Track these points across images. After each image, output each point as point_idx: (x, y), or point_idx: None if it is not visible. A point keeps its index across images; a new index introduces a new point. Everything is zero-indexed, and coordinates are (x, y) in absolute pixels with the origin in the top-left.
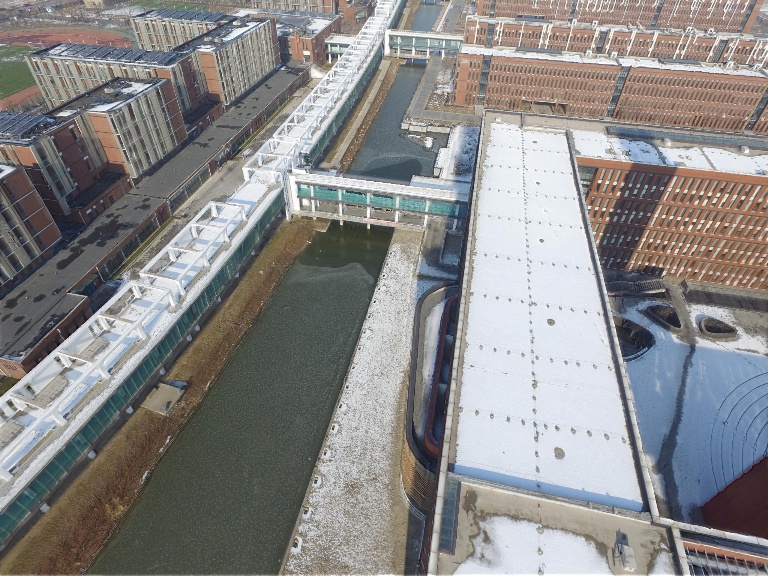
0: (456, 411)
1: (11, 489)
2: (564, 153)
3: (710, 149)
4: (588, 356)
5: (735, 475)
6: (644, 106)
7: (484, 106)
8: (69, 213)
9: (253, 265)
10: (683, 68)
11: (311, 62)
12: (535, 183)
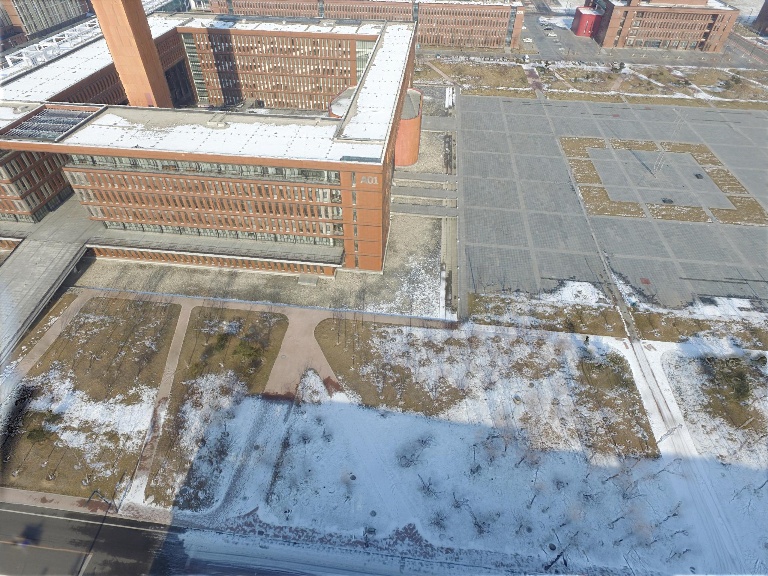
0: None
1: None
2: None
3: (266, 23)
4: (77, 78)
5: None
6: None
7: None
8: None
9: None
10: None
11: None
12: None
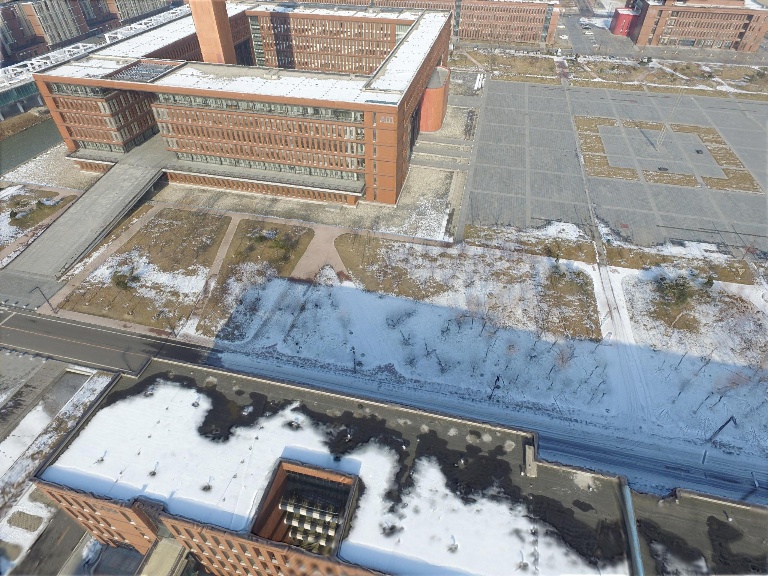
0: (103, 49)
1: None
2: None
3: (320, 9)
4: None
5: None
6: None
7: None
8: (11, 54)
9: None
10: None
11: None
12: None
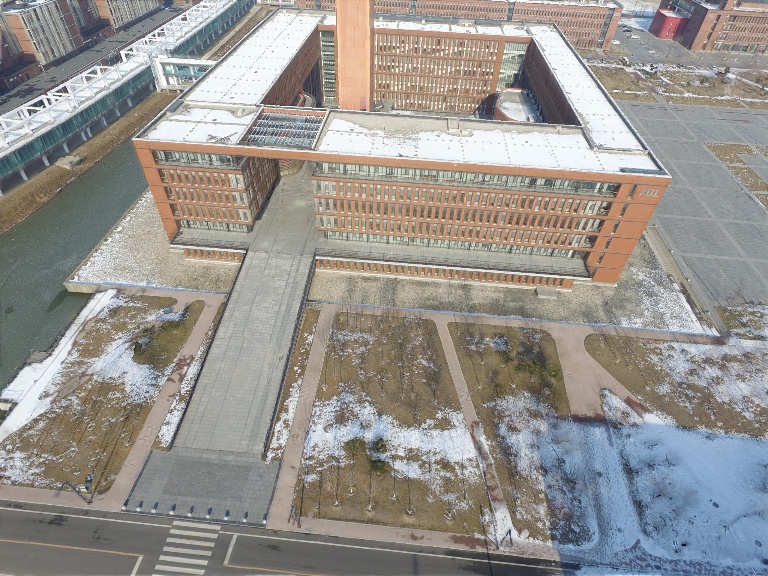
0: (193, 90)
1: None
2: (314, 24)
3: (404, 22)
4: (266, 79)
5: None
6: None
7: None
8: None
9: (131, 111)
10: None
11: (191, 4)
12: (286, 34)
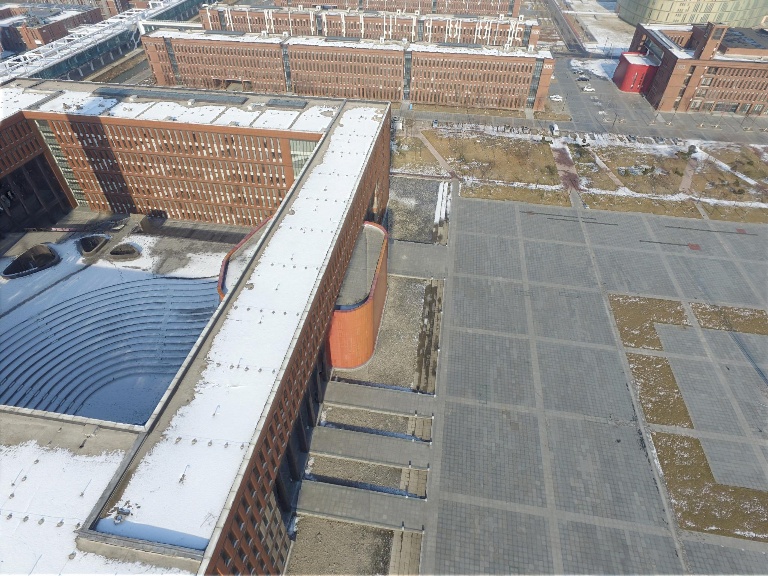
0: None
1: None
2: None
3: (164, 103)
4: None
5: (0, 356)
6: (314, 81)
7: (183, 86)
8: None
9: None
10: (337, 44)
11: None
12: None
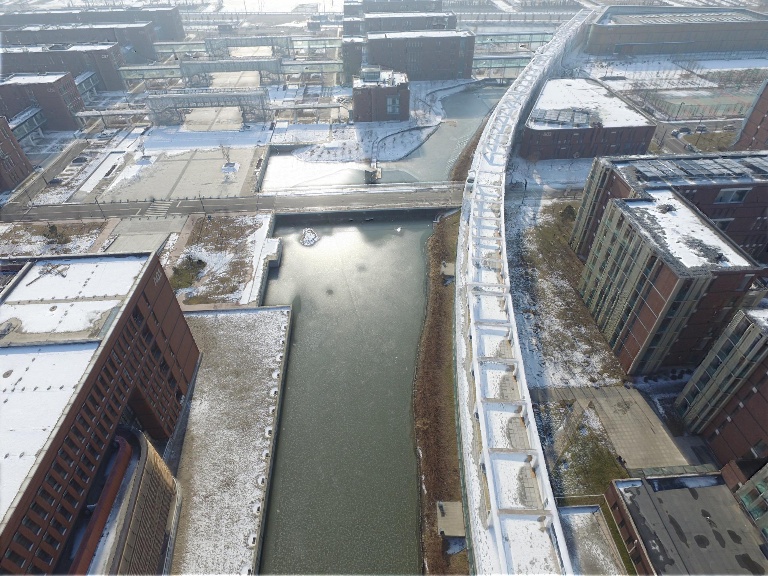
0: None
1: (463, 367)
2: None
3: None
4: None
5: None
6: None
7: None
8: None
9: None
10: None
11: None
12: None
